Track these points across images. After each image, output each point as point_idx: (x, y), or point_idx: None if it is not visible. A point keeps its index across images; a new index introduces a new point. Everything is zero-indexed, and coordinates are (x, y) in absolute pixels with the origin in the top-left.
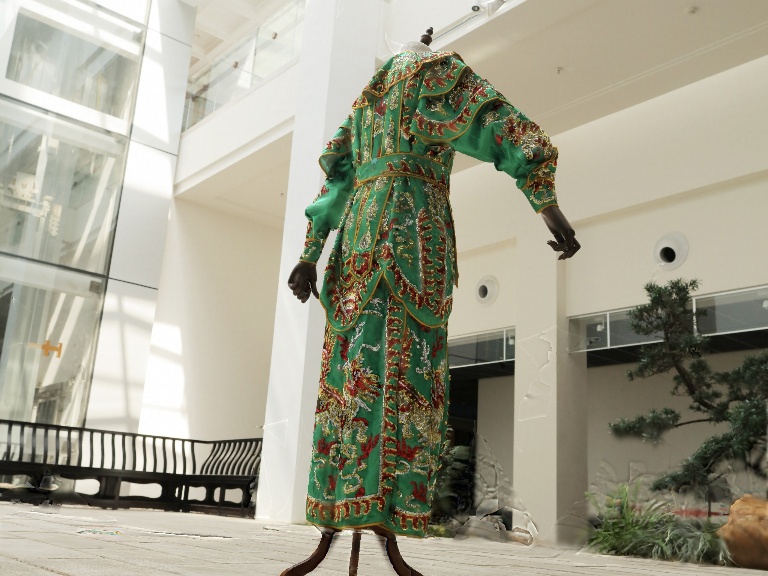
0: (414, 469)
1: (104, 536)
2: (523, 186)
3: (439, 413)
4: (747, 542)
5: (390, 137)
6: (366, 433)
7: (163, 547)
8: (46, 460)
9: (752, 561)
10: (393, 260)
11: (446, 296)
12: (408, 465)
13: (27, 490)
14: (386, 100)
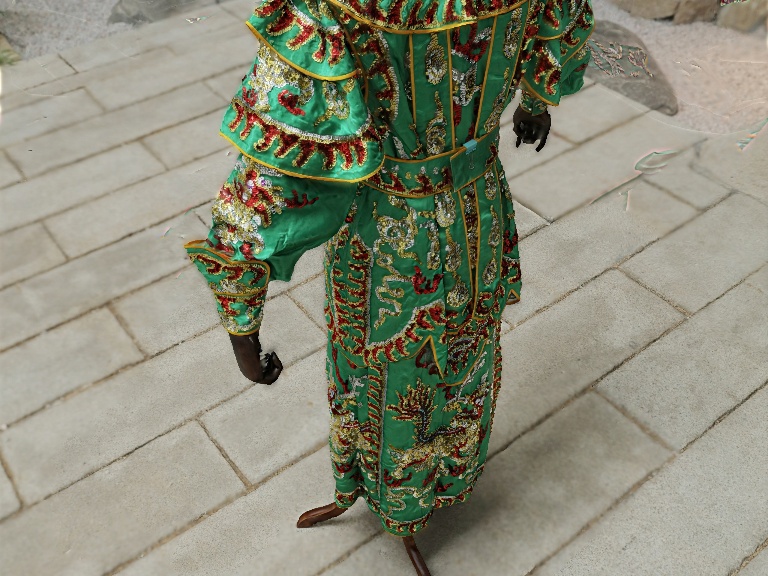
0: None
1: None
2: None
3: None
4: None
5: None
6: None
7: None
8: None
9: None
10: None
11: None
12: None
13: None
14: (487, 32)
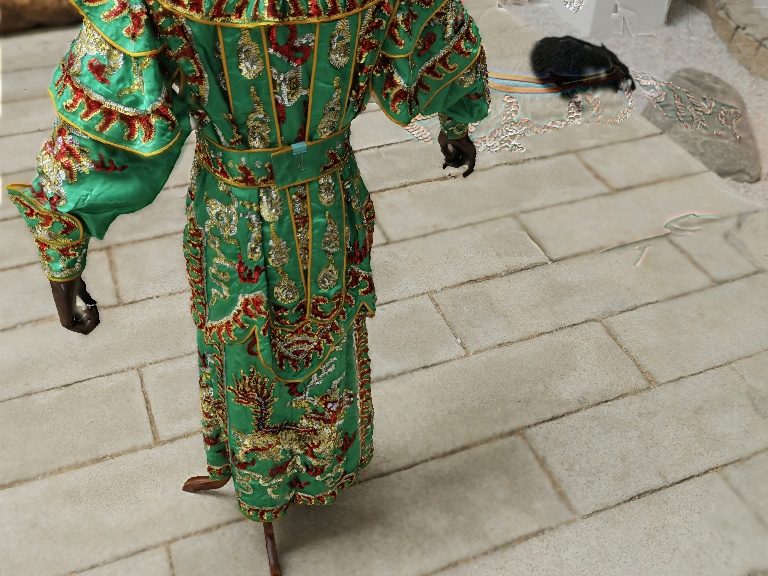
0: None
1: None
2: None
3: None
4: (1, 14)
5: (335, 115)
6: (341, 437)
7: None
8: None
9: (5, 29)
10: None
11: None
12: None
13: None
14: (309, 37)
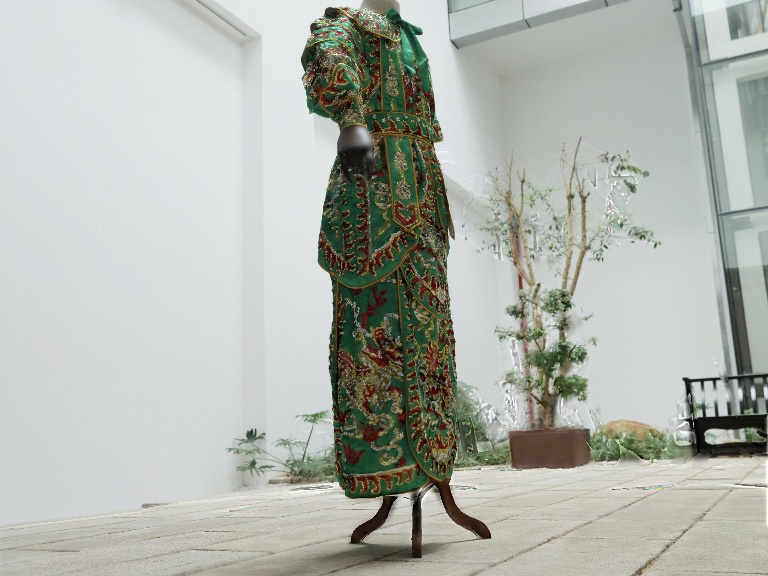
0: (343, 433)
1: (609, 492)
2: None
3: (389, 370)
4: None
5: None
6: None
7: (576, 503)
8: (767, 412)
9: None
10: (321, 239)
11: (375, 250)
12: (342, 429)
13: (734, 445)
14: None
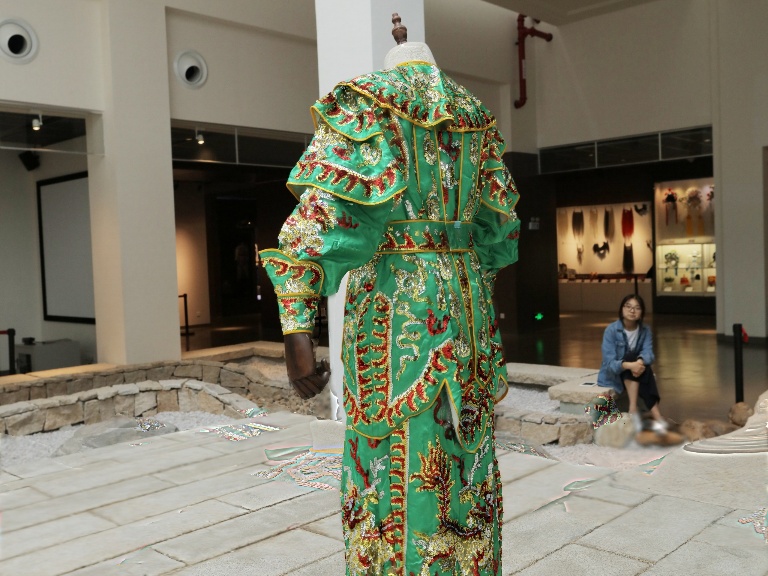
0: None
1: None
2: (491, 274)
3: None
4: None
5: (473, 202)
6: None
7: None
8: None
9: None
10: None
11: None
12: None
13: None
14: (459, 142)
